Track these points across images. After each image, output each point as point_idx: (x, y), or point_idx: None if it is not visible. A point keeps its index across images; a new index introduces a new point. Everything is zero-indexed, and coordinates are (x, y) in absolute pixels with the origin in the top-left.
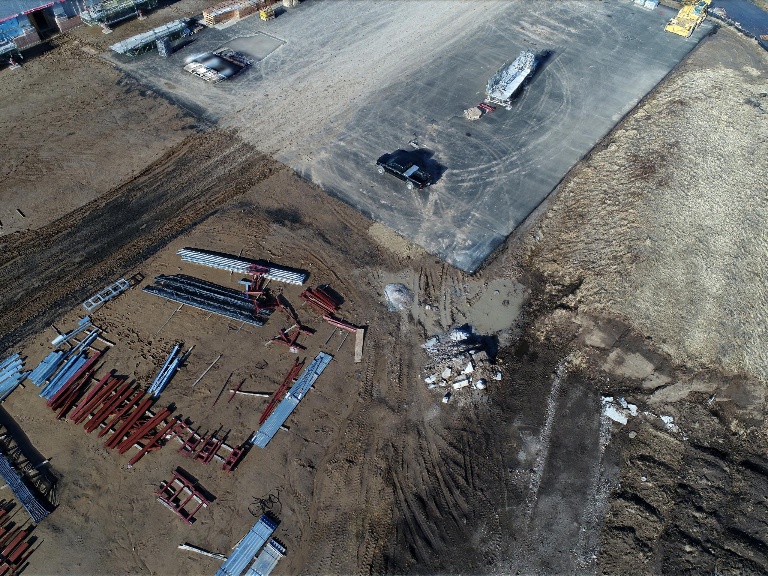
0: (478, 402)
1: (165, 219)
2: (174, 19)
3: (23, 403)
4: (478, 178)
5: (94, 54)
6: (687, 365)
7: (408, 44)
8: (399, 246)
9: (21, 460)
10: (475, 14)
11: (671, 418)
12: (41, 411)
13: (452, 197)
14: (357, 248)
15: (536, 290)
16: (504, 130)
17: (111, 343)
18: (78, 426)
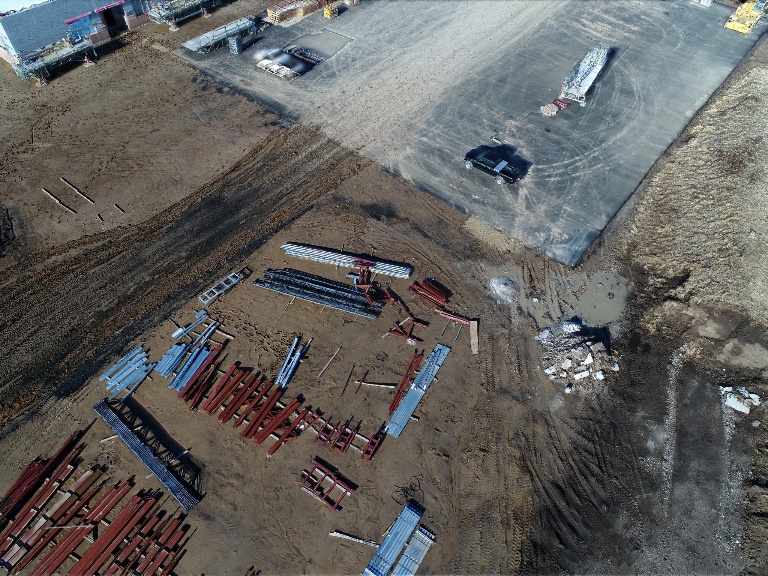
0: (600, 392)
1: (263, 214)
2: (238, 17)
3: (154, 395)
4: (564, 173)
5: (165, 51)
6: None
7: (474, 41)
8: (497, 240)
9: (161, 450)
10: (535, 11)
11: None
12: (173, 402)
13: (542, 192)
14: (456, 242)
15: (639, 283)
16: (582, 126)
17: (231, 336)
18: (212, 417)
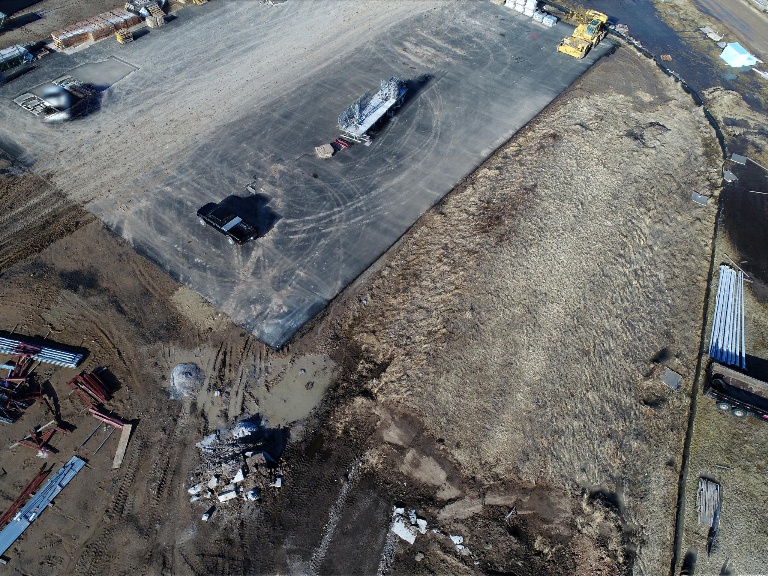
0: (246, 518)
1: None
2: (21, 42)
3: None
4: (314, 229)
5: None
6: (477, 477)
7: (274, 69)
8: (202, 315)
9: None
10: (356, 34)
11: (461, 538)
12: None
13: (278, 253)
14: (153, 319)
15: (348, 368)
16: (357, 170)
17: None
18: None
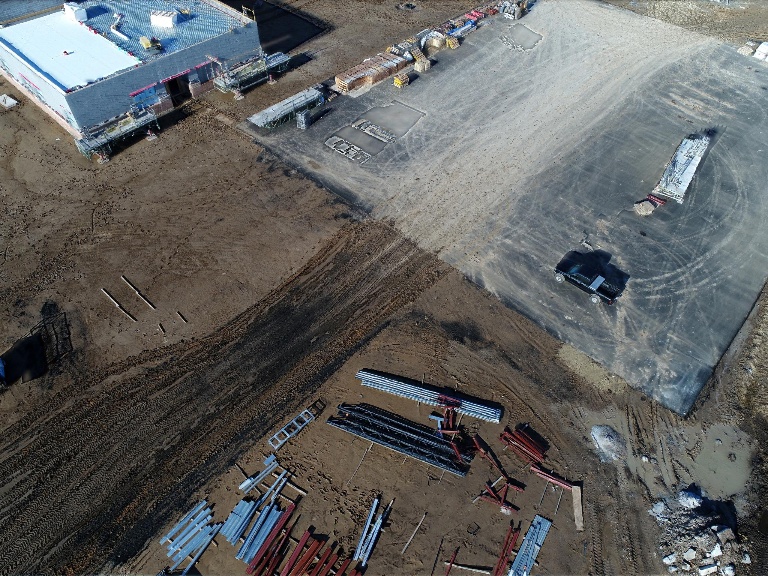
0: None
1: (335, 331)
2: (304, 84)
3: (219, 566)
4: (666, 290)
5: (230, 124)
6: None
7: (555, 119)
8: (596, 376)
9: None
10: (619, 84)
11: None
12: None
13: (642, 314)
14: (550, 376)
15: (764, 442)
16: (681, 229)
17: (303, 491)
18: None
